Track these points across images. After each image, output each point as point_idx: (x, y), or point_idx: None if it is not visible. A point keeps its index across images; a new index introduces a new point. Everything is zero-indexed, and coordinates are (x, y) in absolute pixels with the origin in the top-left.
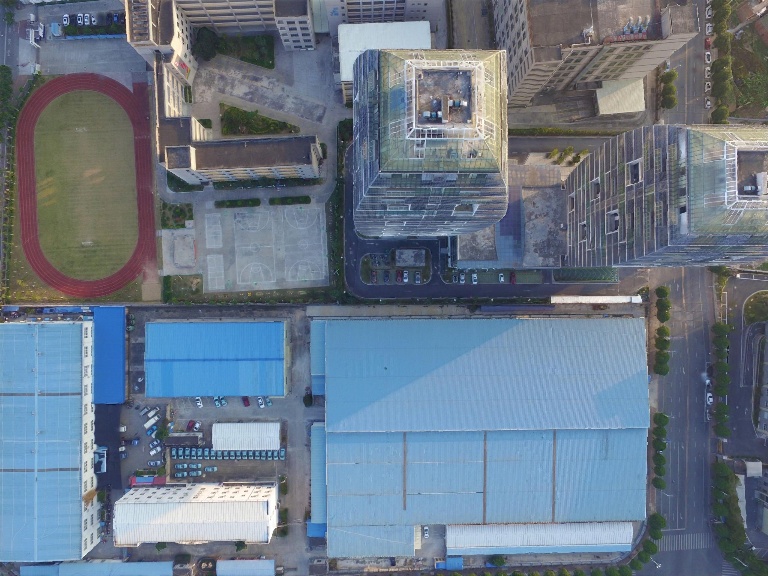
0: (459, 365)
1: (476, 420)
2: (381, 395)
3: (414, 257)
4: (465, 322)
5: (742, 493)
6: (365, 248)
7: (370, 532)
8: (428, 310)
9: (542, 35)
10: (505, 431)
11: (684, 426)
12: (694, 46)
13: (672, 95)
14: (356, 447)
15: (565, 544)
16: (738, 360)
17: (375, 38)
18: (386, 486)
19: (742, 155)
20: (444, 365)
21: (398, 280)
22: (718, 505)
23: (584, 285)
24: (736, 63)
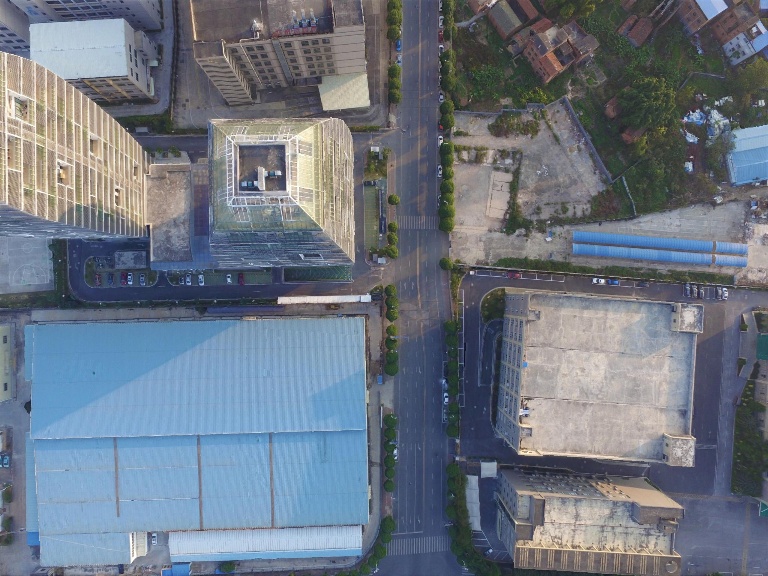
0: (170, 368)
1: (186, 424)
2: (88, 400)
3: (134, 259)
4: (178, 325)
5: (476, 494)
6: (89, 251)
7: (84, 540)
8: (156, 313)
9: (210, 31)
10: (218, 435)
11: (421, 427)
12: (428, 39)
13: (394, 90)
14: (65, 454)
15: (292, 549)
16: (476, 359)
17: (67, 37)
18: (98, 493)
19: (245, 150)
20: (154, 369)
21: (122, 283)
22: (448, 507)
23: (316, 285)
24: (468, 56)
